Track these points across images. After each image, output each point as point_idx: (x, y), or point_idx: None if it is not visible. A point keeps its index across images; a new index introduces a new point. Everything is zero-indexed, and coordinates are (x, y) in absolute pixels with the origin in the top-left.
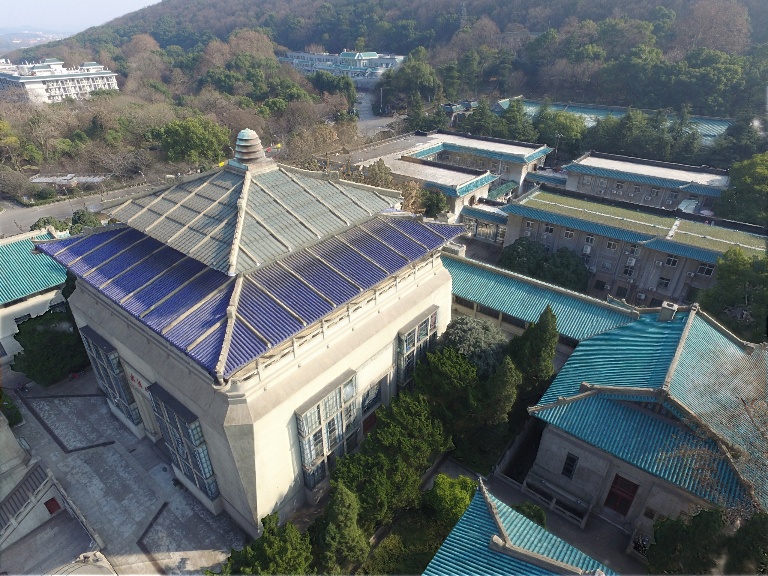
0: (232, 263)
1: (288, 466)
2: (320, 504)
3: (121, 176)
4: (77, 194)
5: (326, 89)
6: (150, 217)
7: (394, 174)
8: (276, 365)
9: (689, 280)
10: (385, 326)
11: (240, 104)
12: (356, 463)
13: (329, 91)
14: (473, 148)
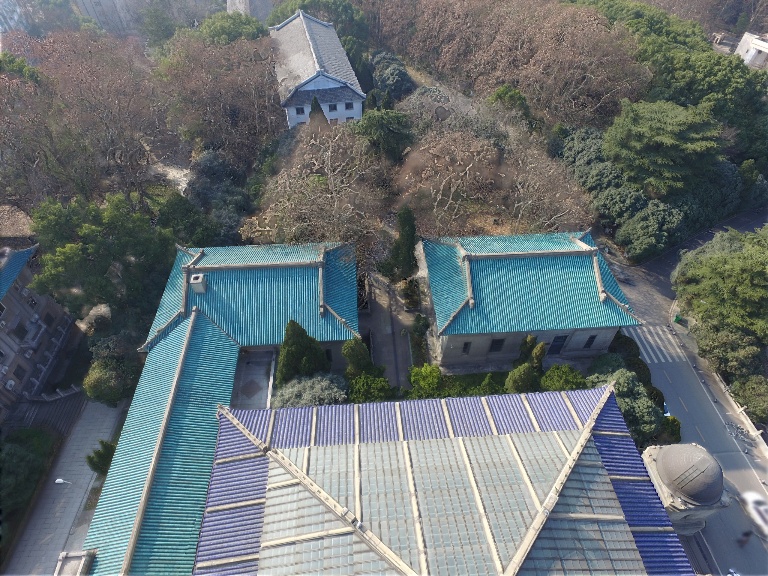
0: None
1: None
2: None
3: None
4: None
5: None
6: None
7: None
8: None
9: (5, 329)
10: None
11: None
12: None
13: None
14: None
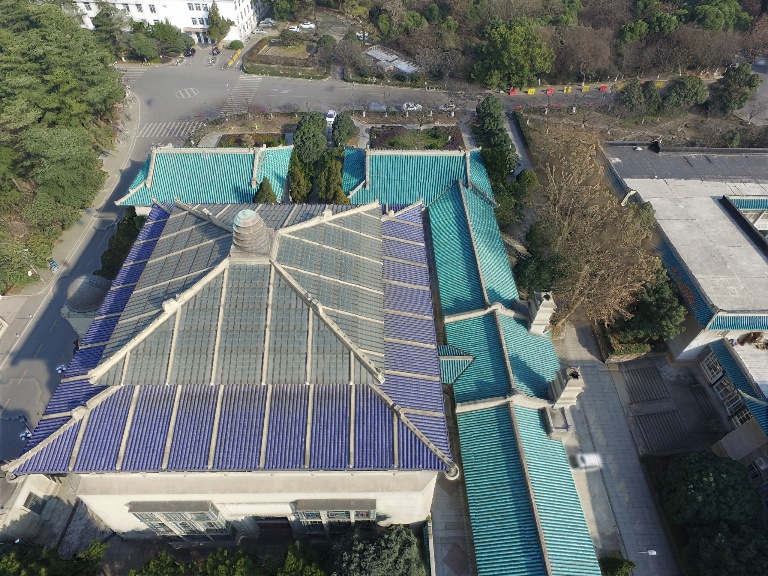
0: (90, 376)
1: (139, 520)
2: (177, 552)
3: (426, 74)
4: (383, 81)
5: None
6: (167, 247)
7: (660, 230)
8: None
9: None
10: (270, 492)
11: (637, 0)
12: (162, 575)
13: None
14: None
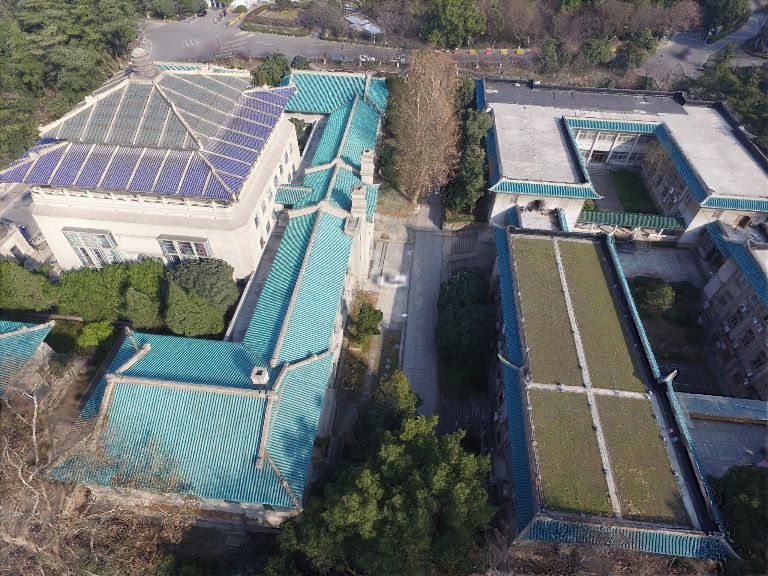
0: None
1: (74, 254)
2: None
3: None
4: (351, 40)
5: None
6: None
7: (494, 132)
8: (54, 196)
9: None
10: (142, 223)
11: None
12: None
13: None
14: (679, 148)
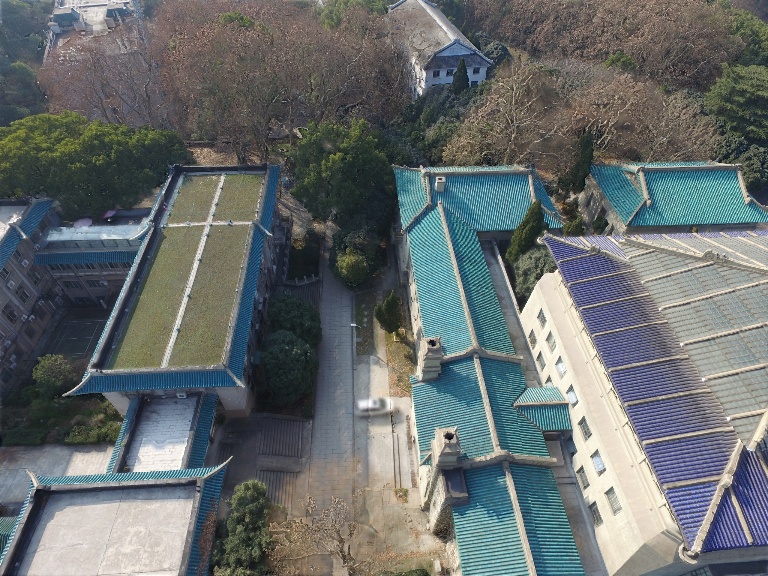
0: None
1: None
2: None
3: None
4: None
5: None
6: None
7: None
8: None
9: None
10: None
11: None
12: None
13: None
14: None
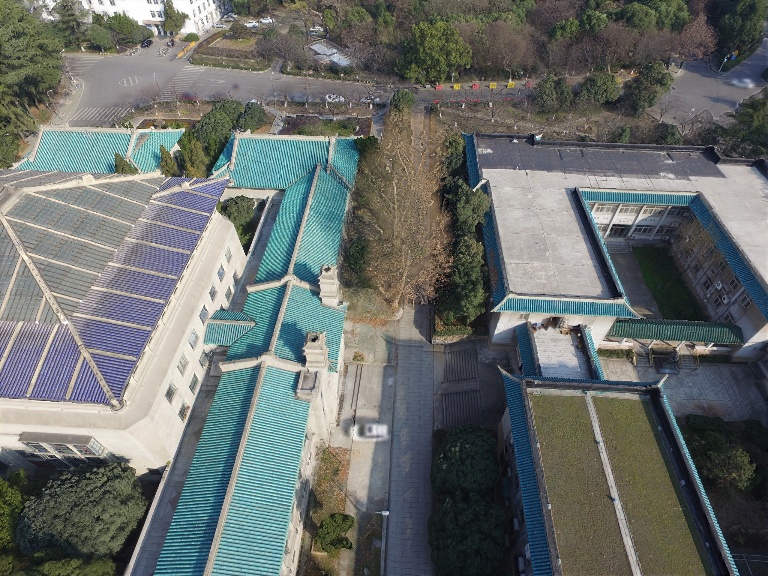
0: None
1: None
2: None
3: None
4: (316, 74)
5: (726, 5)
6: None
7: (493, 217)
8: None
9: None
10: None
11: None
12: None
13: (726, 10)
14: (726, 233)
